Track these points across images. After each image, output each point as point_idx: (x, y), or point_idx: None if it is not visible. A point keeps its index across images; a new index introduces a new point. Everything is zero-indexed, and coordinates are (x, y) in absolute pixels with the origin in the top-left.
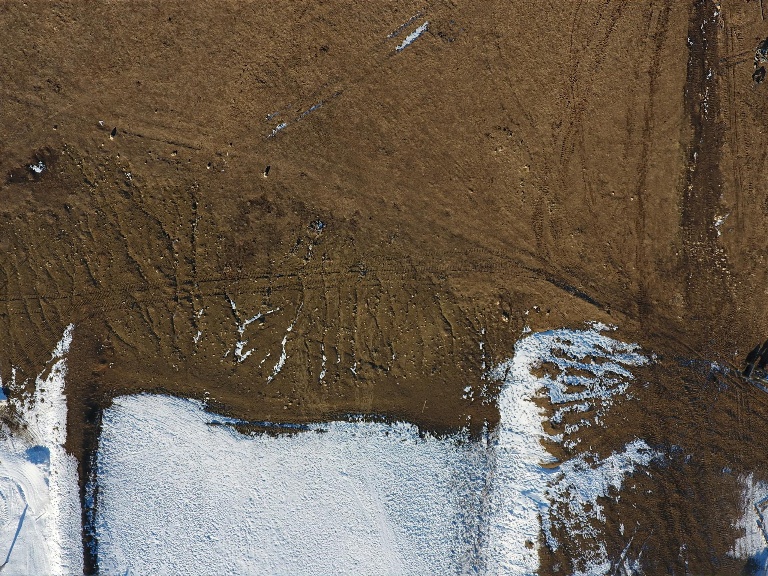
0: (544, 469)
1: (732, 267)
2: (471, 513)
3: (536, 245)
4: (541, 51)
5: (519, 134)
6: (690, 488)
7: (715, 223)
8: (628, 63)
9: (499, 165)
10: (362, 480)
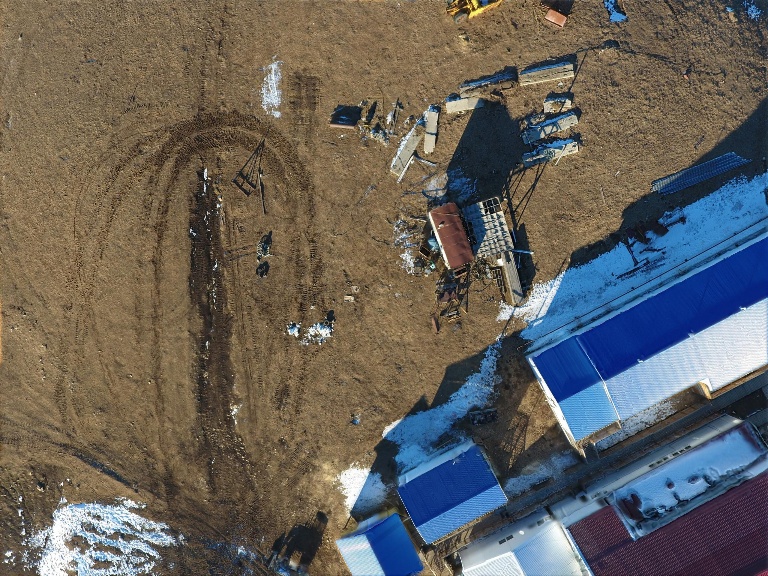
0: None
1: (250, 456)
2: None
3: (61, 421)
4: (47, 235)
5: (33, 314)
6: None
7: (232, 412)
8: (131, 251)
9: (17, 342)
10: None
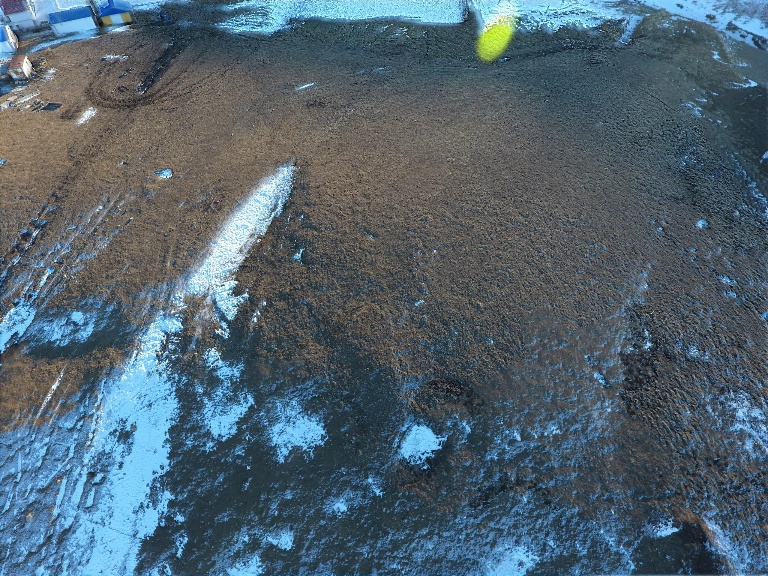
0: (274, 6)
1: None
2: (308, 3)
3: None
4: None
5: None
6: (215, 0)
7: None
8: None
9: None
10: (353, 8)
